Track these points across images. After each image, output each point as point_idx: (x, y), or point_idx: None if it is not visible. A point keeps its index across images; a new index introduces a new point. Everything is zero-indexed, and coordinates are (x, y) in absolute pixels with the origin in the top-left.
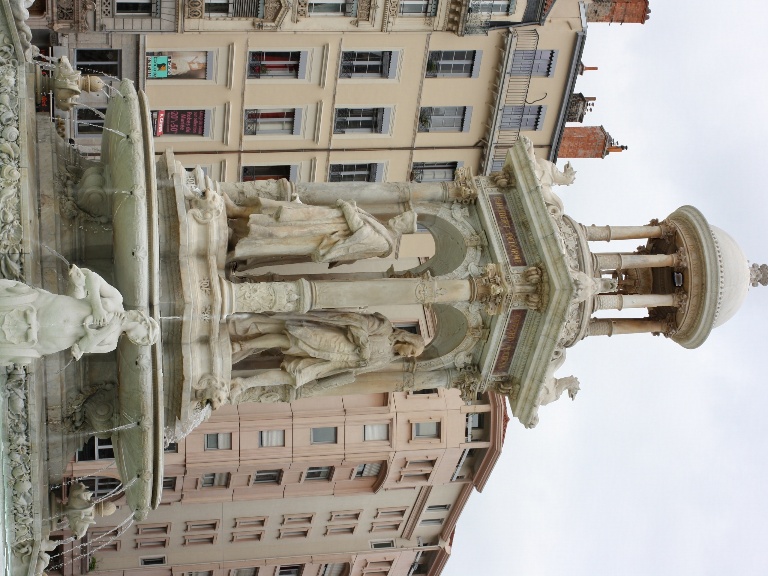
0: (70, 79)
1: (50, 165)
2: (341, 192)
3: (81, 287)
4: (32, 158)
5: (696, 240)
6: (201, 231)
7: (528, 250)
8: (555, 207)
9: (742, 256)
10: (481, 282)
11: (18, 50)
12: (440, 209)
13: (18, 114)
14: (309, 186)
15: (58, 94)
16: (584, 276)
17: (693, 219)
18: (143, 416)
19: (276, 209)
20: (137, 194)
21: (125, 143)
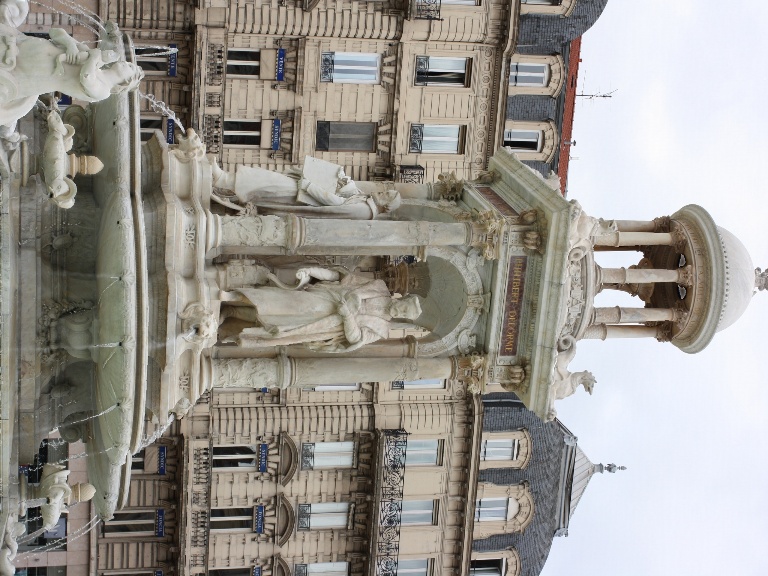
0: None
1: (33, 318)
2: (354, 243)
3: None
4: None
5: (705, 305)
6: (189, 345)
7: (524, 338)
8: (580, 252)
9: (747, 303)
10: (463, 374)
11: (2, 170)
12: (456, 254)
13: (0, 339)
14: (320, 237)
15: None
16: (563, 390)
17: (714, 283)
18: (106, 518)
19: (273, 315)
20: None
21: (115, 401)
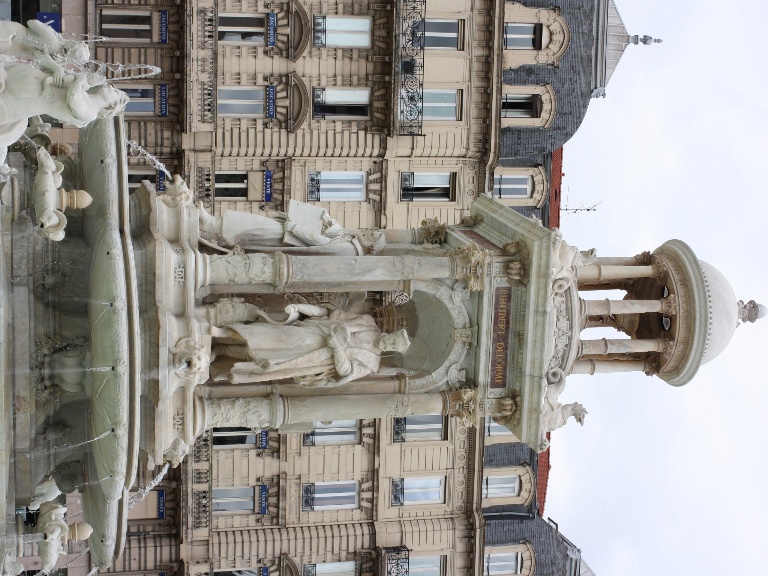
0: (53, 232)
1: (27, 352)
2: (340, 278)
3: (54, 540)
4: (8, 366)
5: (690, 333)
6: (181, 382)
7: (513, 370)
8: (563, 283)
9: (731, 333)
10: (454, 408)
11: None
12: (441, 287)
13: None
14: (307, 272)
15: (38, 231)
16: (555, 421)
17: (697, 311)
18: (104, 565)
19: (264, 349)
20: (117, 479)
21: (109, 427)
